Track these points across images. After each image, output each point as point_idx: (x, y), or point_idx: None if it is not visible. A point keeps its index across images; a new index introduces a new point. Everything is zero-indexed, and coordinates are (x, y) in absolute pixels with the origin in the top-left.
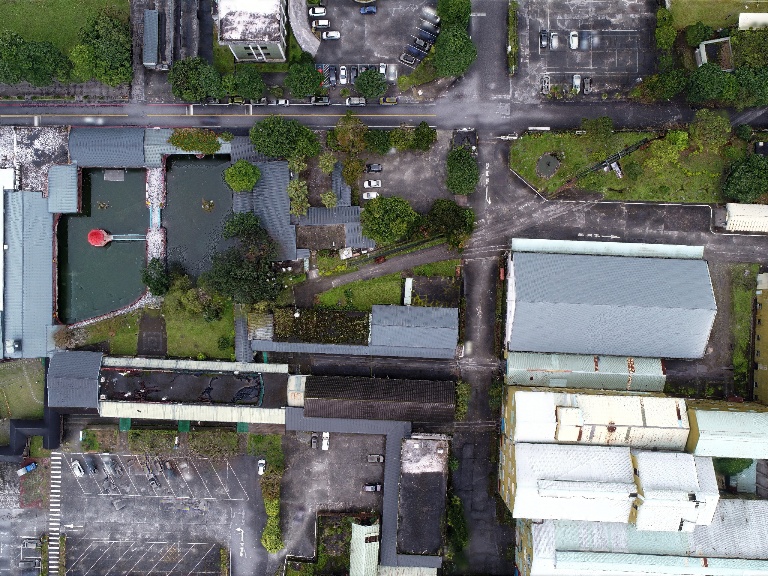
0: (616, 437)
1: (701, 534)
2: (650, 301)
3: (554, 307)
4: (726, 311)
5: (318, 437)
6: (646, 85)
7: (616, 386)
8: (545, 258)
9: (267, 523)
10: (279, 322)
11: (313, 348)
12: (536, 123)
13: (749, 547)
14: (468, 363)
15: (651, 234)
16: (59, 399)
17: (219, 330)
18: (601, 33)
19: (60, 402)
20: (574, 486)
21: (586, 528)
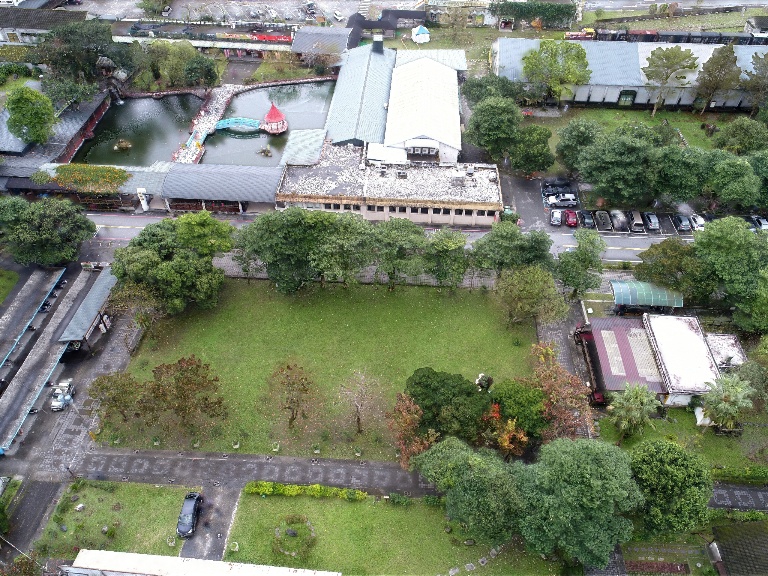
0: None
1: None
2: None
3: None
4: None
5: None
6: None
7: None
8: None
9: None
10: None
11: None
12: None
13: None
14: None
15: None
16: (341, 29)
17: None
18: None
19: None
20: None
21: None
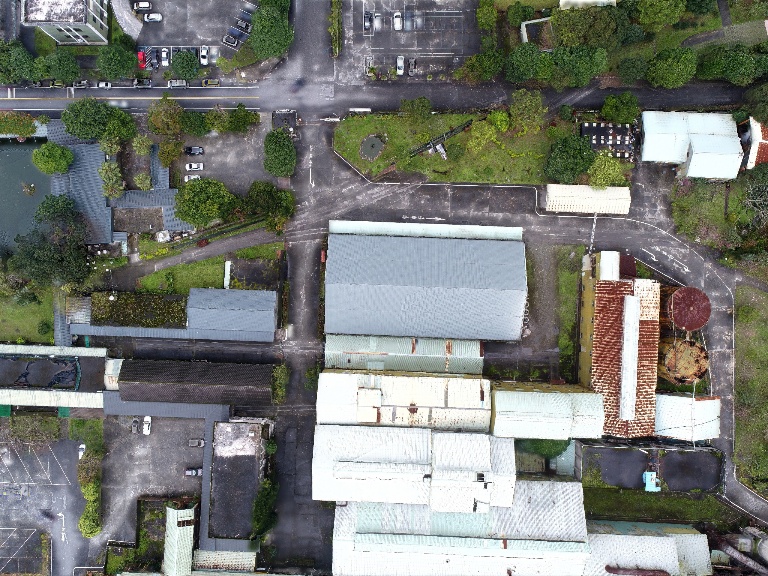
0: (419, 418)
1: (506, 516)
2: (461, 282)
3: (364, 289)
4: (551, 293)
5: (140, 421)
6: (466, 66)
7: (434, 369)
8: (361, 240)
9: (85, 508)
10: (96, 306)
11: (131, 332)
12: (360, 105)
13: (553, 529)
14: (291, 346)
15: (476, 216)
16: None
17: (40, 314)
18: (426, 14)
19: None
20: (368, 467)
21: (390, 510)
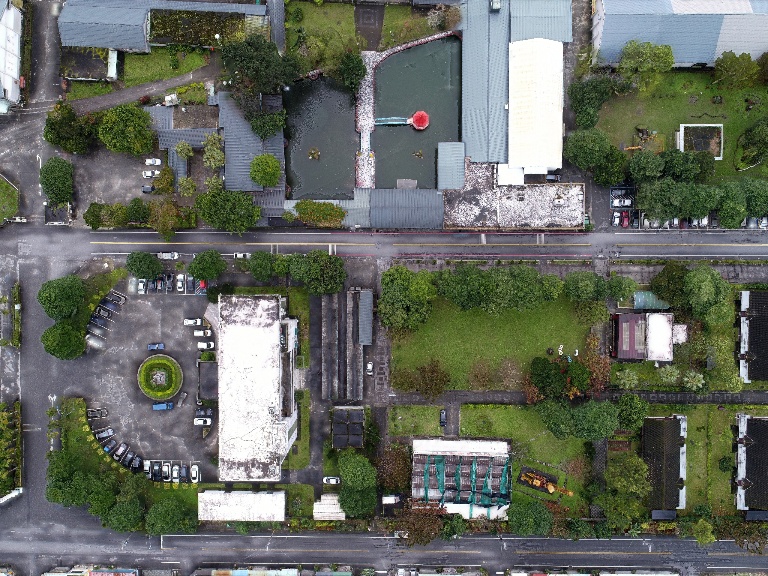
0: None
1: None
2: None
3: None
4: None
5: None
6: None
7: None
8: None
9: None
10: None
11: (205, 7)
12: None
13: None
14: None
15: None
16: None
17: None
18: None
19: None
20: None
21: None
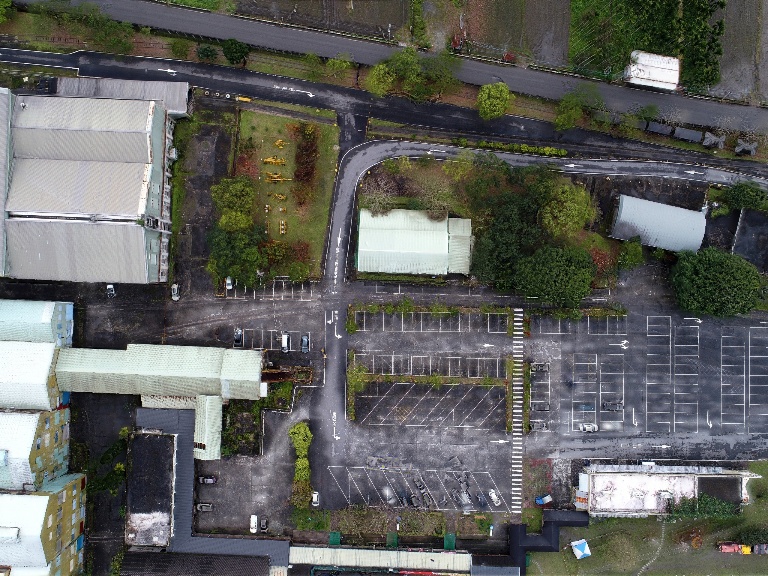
0: None
1: None
2: None
3: None
4: None
5: None
6: None
7: None
8: None
9: None
10: None
11: None
12: None
13: None
14: None
15: None
16: (509, 575)
17: None
18: None
19: (508, 572)
20: None
21: None
